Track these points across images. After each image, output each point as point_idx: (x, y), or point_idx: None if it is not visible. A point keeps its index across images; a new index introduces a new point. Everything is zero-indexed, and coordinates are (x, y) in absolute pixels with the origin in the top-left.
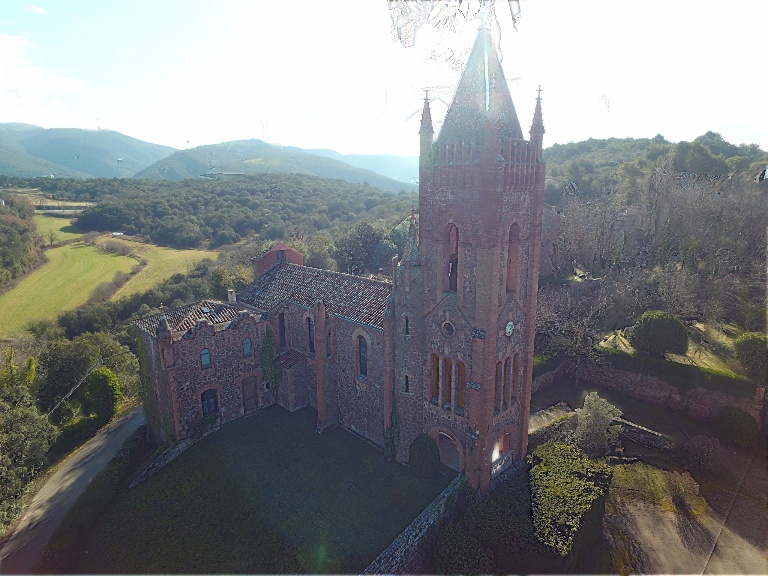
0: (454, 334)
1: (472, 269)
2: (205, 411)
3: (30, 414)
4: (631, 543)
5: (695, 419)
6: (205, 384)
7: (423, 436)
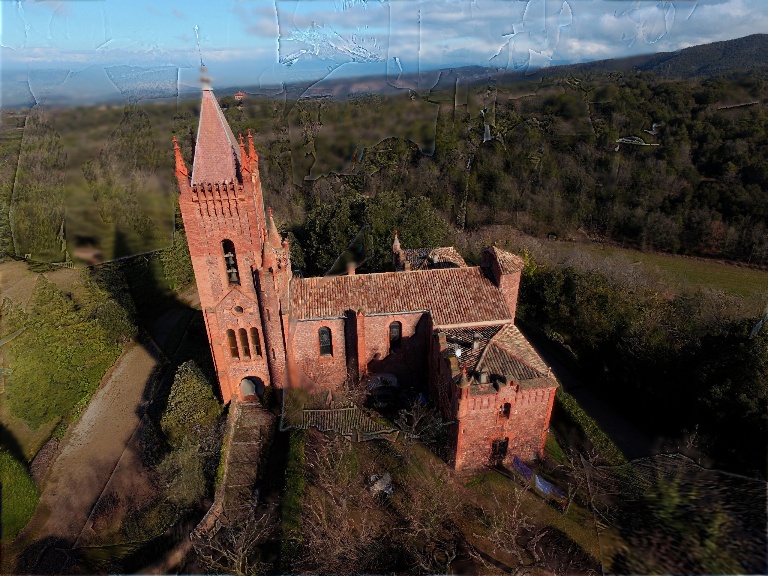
0: None
1: None
2: None
3: None
4: None
5: None
6: None
7: None
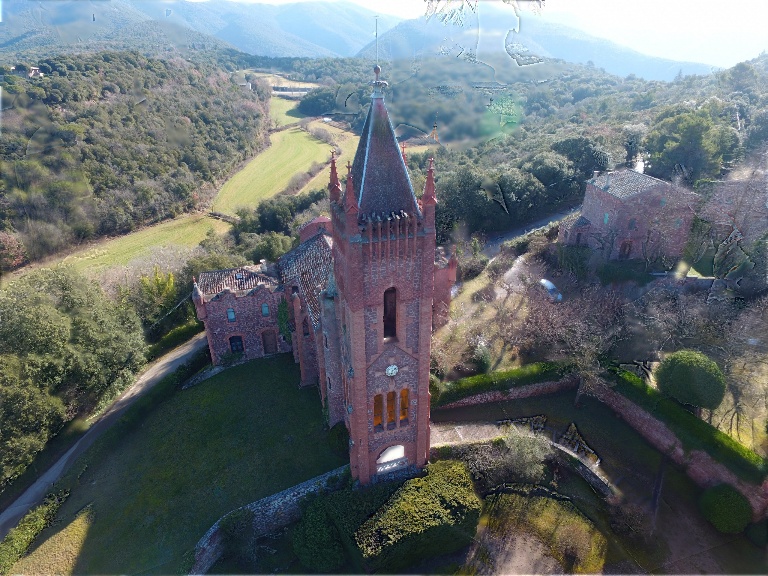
0: None
1: None
2: (234, 349)
3: (120, 336)
4: (486, 567)
5: (692, 480)
6: (232, 332)
7: (340, 424)
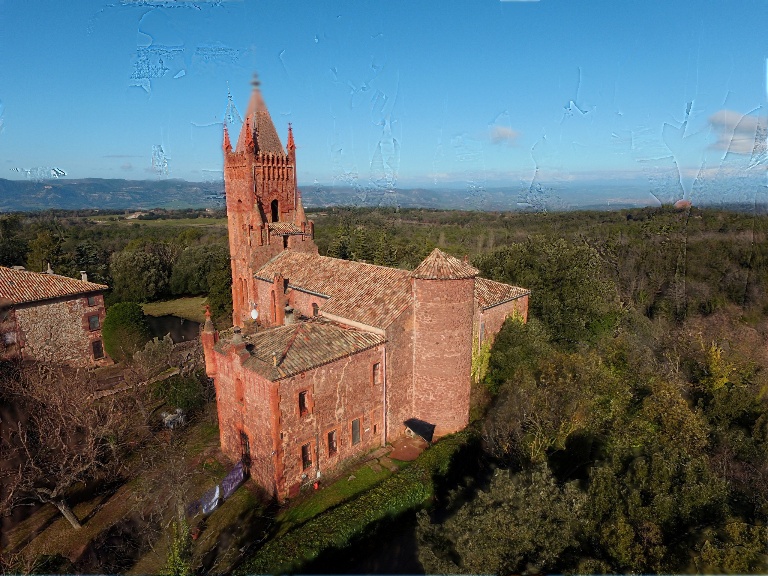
0: None
1: None
2: None
3: None
4: None
5: None
6: None
7: None
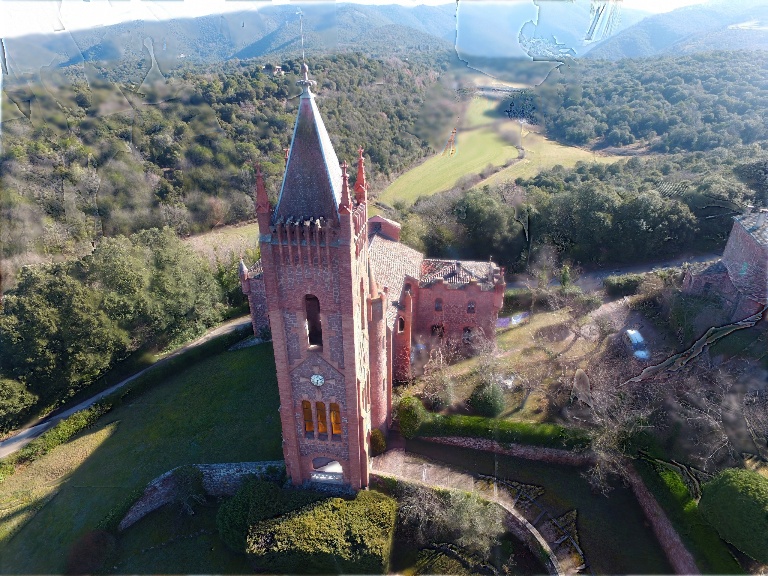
0: None
1: None
2: None
3: (187, 293)
4: None
5: None
6: None
7: None
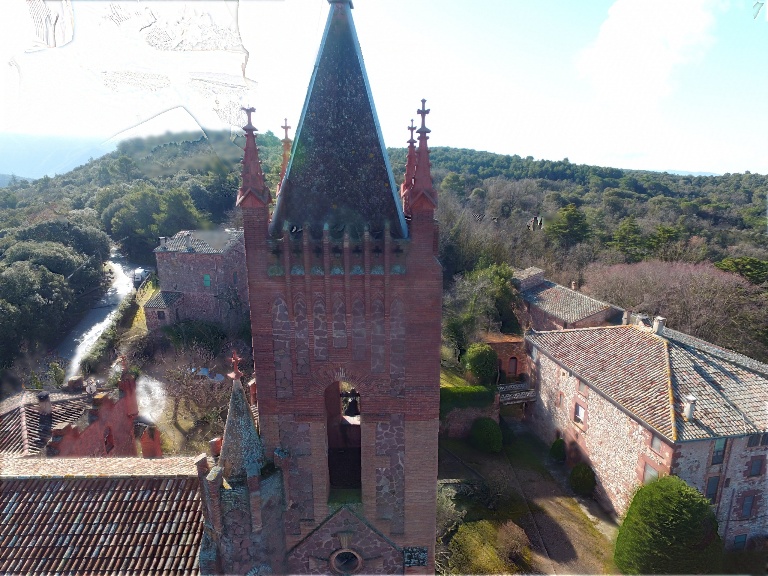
0: (361, 568)
1: (394, 456)
2: None
3: None
4: None
5: (455, 438)
6: None
7: None
